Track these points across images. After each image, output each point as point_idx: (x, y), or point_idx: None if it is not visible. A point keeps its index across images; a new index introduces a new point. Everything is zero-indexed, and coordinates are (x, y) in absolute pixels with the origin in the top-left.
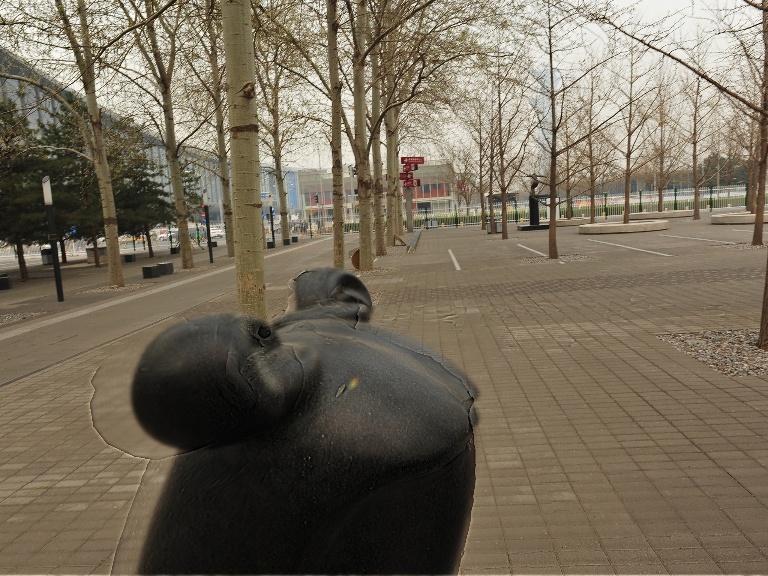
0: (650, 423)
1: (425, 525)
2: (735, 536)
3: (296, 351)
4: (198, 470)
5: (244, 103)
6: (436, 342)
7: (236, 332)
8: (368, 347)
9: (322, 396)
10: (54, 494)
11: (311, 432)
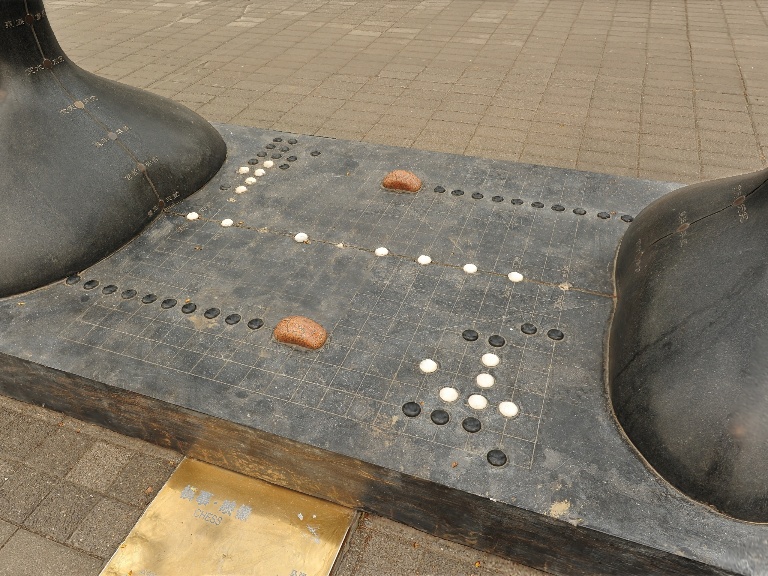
0: (664, 7)
1: None
2: (634, 79)
3: None
4: None
5: None
6: None
7: None
8: None
9: None
10: (114, 3)
11: None
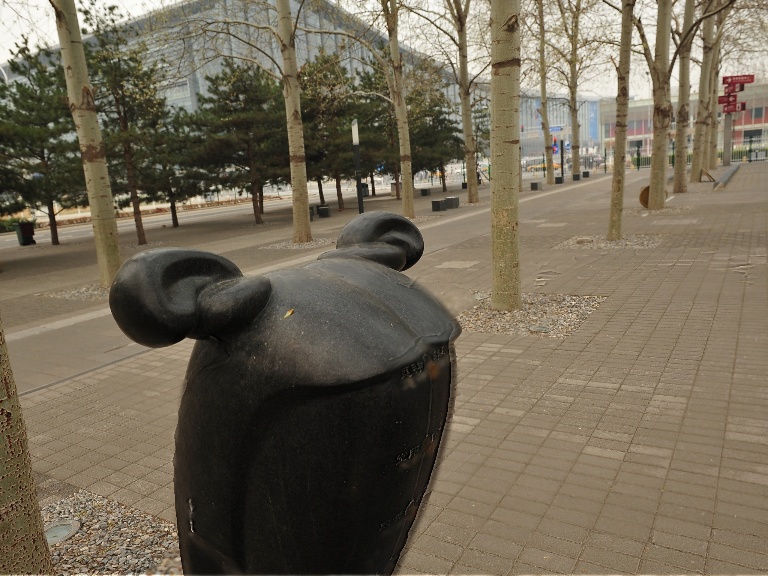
0: None
1: (342, 423)
2: None
3: (279, 282)
4: (212, 357)
5: (507, 37)
6: (714, 294)
7: (210, 264)
8: (344, 284)
9: (274, 316)
10: None
11: (259, 340)
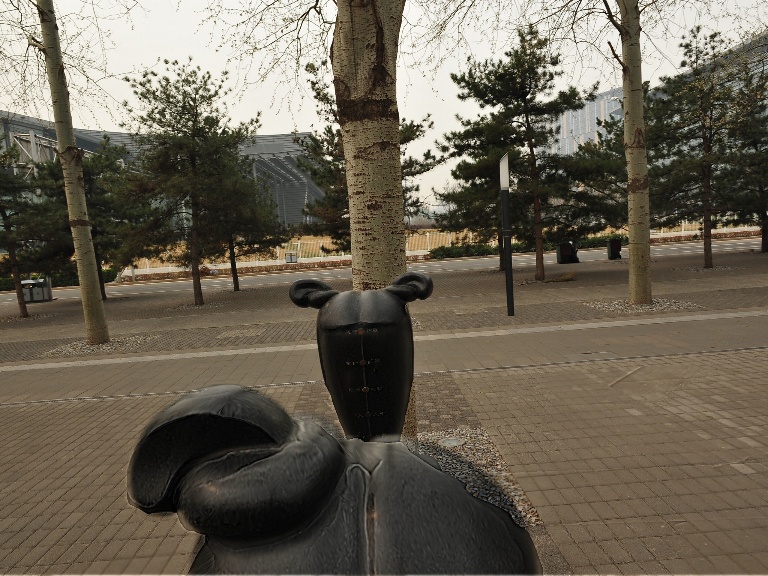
0: None
1: None
2: None
3: None
4: None
5: None
6: None
7: (317, 285)
8: None
9: None
10: (709, 423)
11: None
